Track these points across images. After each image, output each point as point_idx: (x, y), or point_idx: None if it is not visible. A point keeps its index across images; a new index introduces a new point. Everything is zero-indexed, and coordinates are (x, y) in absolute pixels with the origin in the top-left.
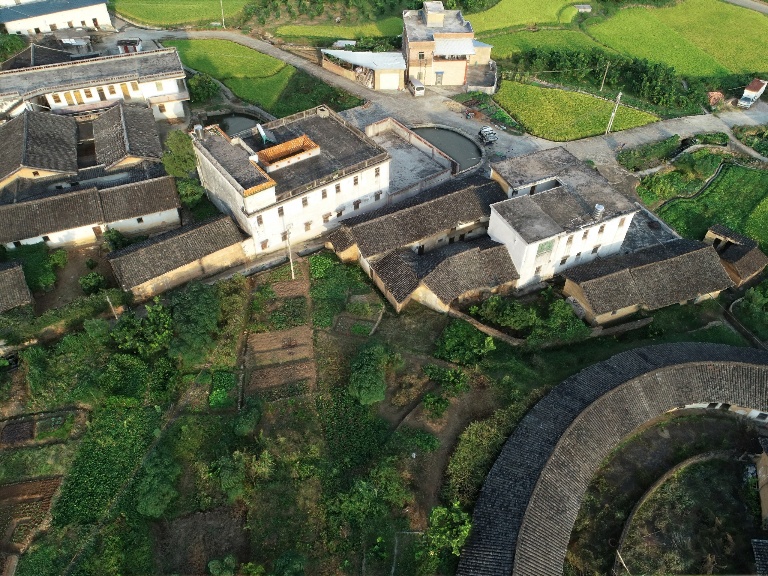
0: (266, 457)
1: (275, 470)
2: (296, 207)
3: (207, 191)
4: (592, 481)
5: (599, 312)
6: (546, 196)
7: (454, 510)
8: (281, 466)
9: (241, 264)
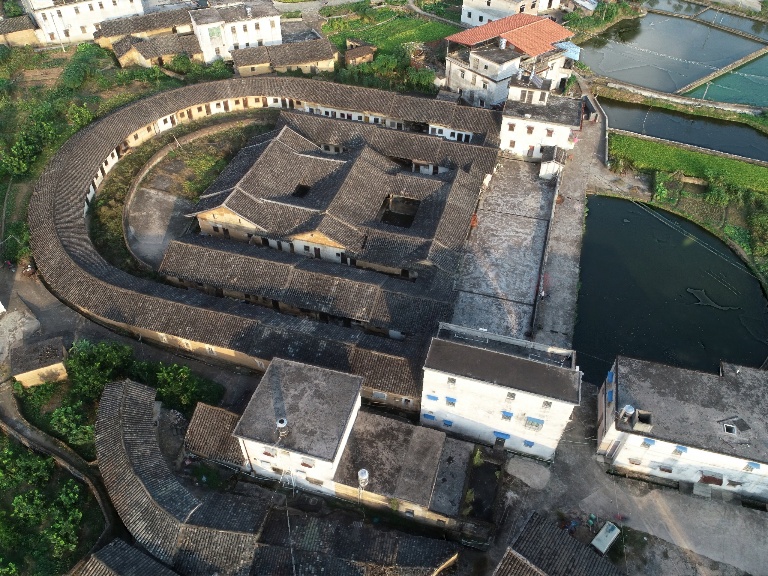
0: (3, 99)
1: (9, 107)
2: (71, 13)
3: (28, 14)
4: (189, 125)
5: (239, 65)
6: (228, 9)
7: (84, 108)
8: (13, 107)
9: (37, 47)
